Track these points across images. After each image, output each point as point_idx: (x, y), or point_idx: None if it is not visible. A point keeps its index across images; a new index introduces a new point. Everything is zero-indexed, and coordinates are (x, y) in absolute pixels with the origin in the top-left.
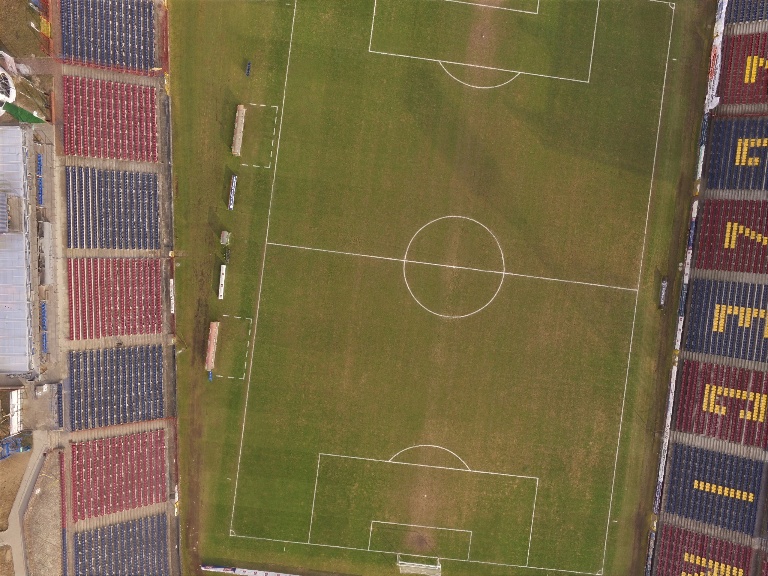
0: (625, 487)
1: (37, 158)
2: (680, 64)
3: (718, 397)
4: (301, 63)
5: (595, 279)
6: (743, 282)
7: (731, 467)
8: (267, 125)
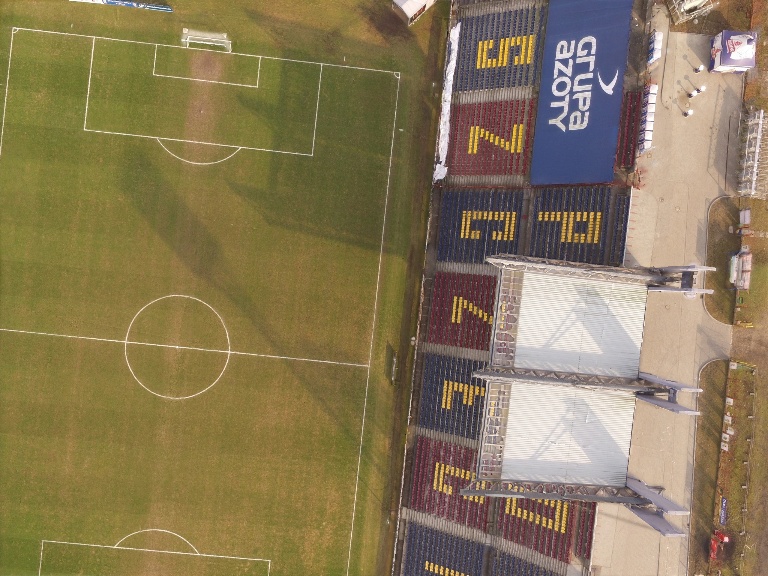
0: (361, 568)
1: None
2: (407, 134)
3: (446, 476)
4: (14, 144)
5: (324, 356)
6: (468, 358)
7: (456, 549)
8: None
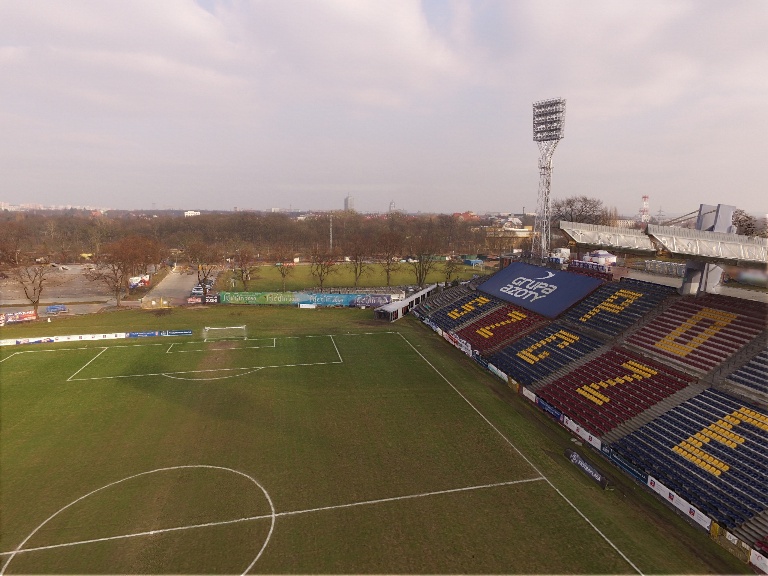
0: None
1: None
2: None
3: None
4: None
5: (460, 482)
6: (663, 414)
7: None
8: None
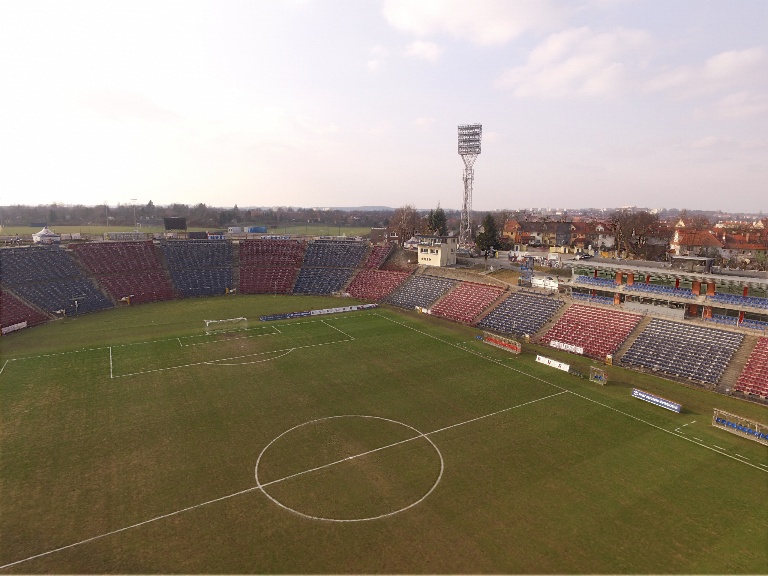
0: None
1: (760, 327)
2: None
3: None
4: None
5: (19, 571)
6: None
7: None
8: (760, 457)
